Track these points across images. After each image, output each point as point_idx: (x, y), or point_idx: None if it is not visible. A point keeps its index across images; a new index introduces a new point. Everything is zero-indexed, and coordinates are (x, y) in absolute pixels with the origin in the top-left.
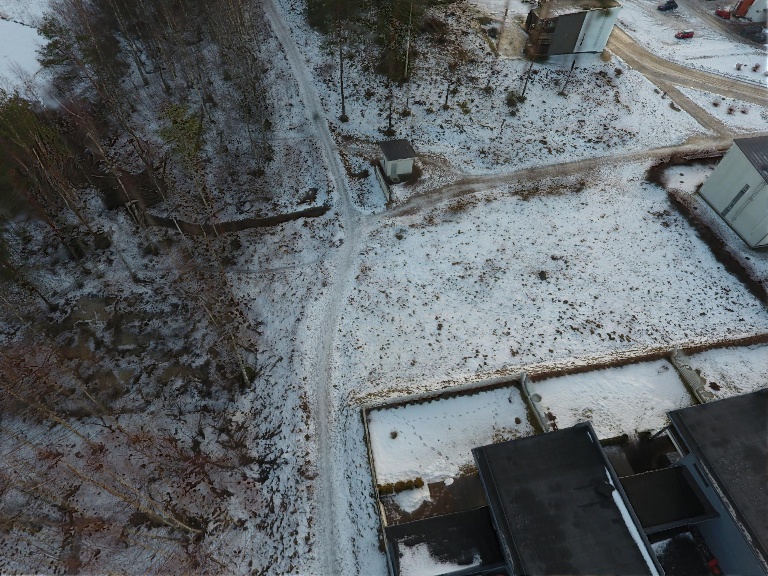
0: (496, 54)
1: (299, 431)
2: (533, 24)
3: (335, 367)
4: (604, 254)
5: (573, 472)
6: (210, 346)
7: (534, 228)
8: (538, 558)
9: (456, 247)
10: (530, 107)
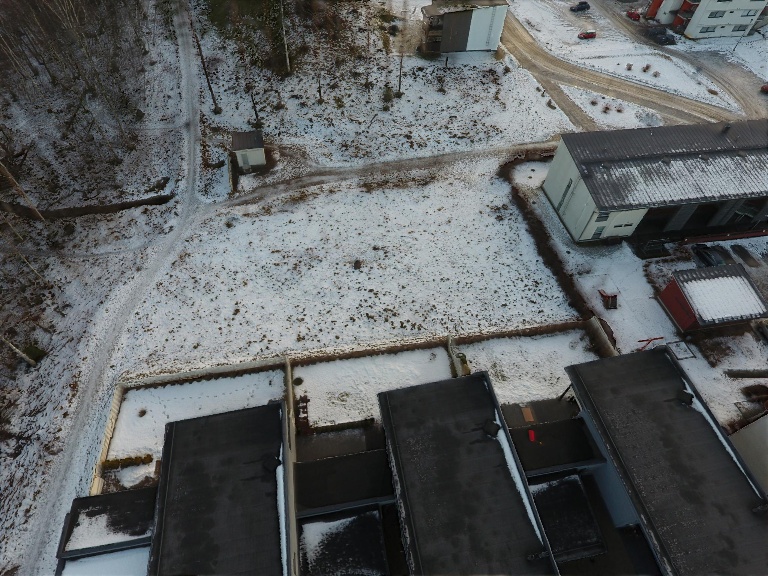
0: (387, 51)
1: (60, 408)
2: (425, 22)
3: (119, 348)
4: (427, 245)
5: (250, 447)
6: (10, 326)
7: (366, 219)
8: (181, 528)
9: (281, 236)
10: (406, 102)
